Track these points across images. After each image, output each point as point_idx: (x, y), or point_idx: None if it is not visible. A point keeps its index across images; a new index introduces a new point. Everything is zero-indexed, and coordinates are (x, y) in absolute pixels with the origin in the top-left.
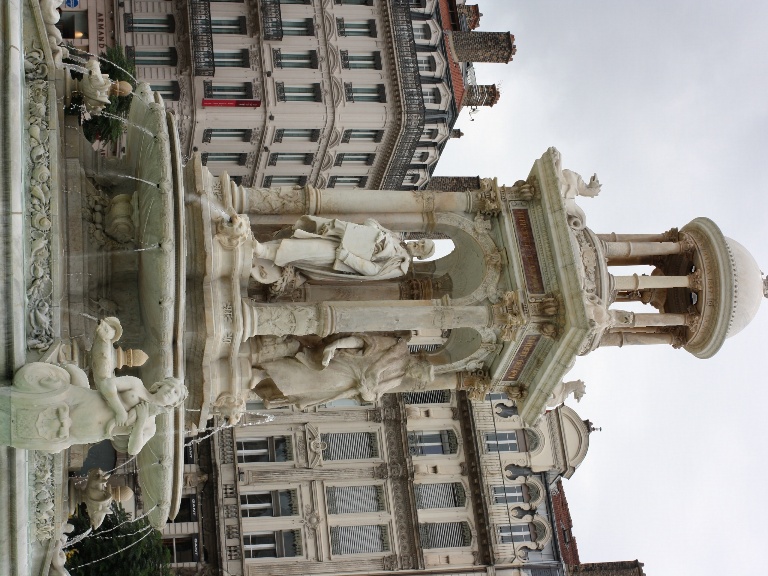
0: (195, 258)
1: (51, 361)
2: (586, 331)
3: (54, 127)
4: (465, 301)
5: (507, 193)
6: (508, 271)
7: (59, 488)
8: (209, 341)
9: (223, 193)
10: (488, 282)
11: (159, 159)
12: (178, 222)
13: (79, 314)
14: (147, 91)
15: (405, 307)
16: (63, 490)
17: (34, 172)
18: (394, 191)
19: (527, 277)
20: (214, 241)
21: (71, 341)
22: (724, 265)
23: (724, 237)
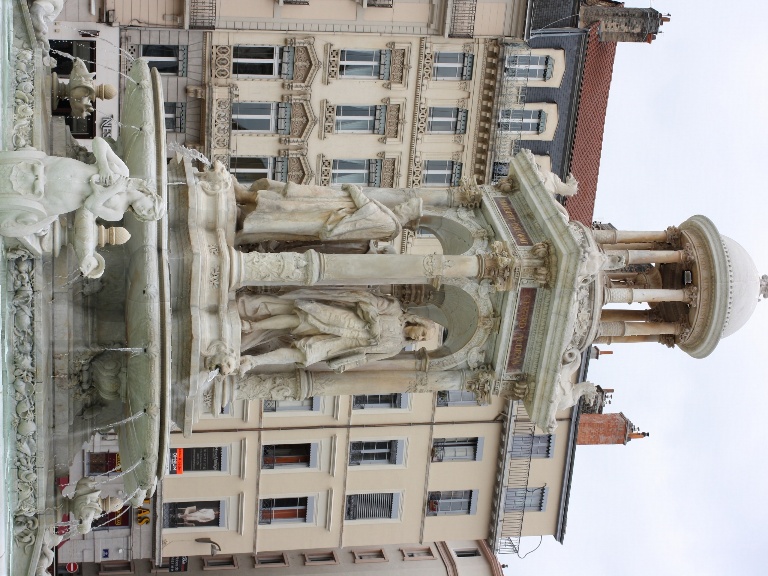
0: None
1: None
2: (521, 151)
3: None
4: None
5: None
6: None
7: (39, 71)
8: (179, 153)
9: None
10: None
11: None
12: None
13: None
14: None
15: None
16: (44, 126)
17: None
18: None
19: None
20: None
21: None
22: None
23: None
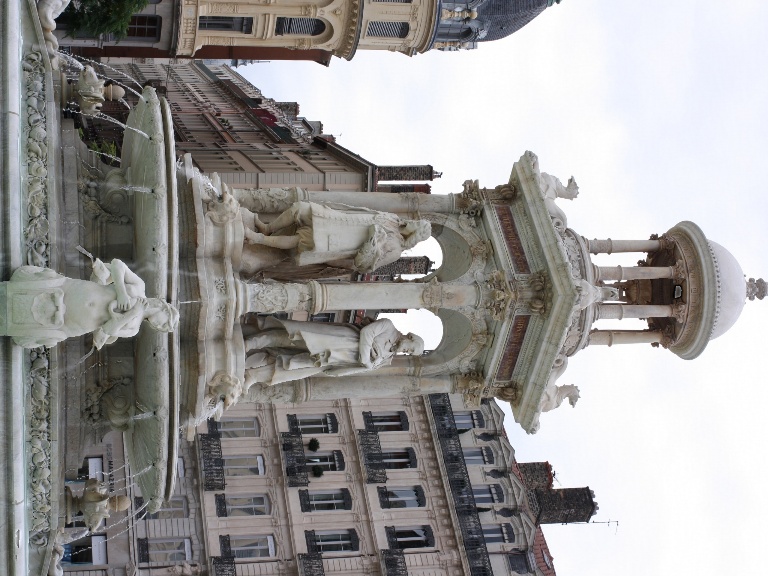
0: (185, 406)
1: (49, 567)
2: None
3: (56, 439)
4: (437, 368)
5: (518, 303)
6: (488, 350)
7: None
8: None
9: (226, 317)
10: (466, 354)
11: (155, 484)
12: (167, 497)
13: (74, 456)
14: (160, 252)
15: (376, 389)
16: None
17: (36, 476)
18: (403, 299)
19: (500, 368)
20: (205, 399)
21: (66, 511)
22: (697, 347)
23: (720, 306)
